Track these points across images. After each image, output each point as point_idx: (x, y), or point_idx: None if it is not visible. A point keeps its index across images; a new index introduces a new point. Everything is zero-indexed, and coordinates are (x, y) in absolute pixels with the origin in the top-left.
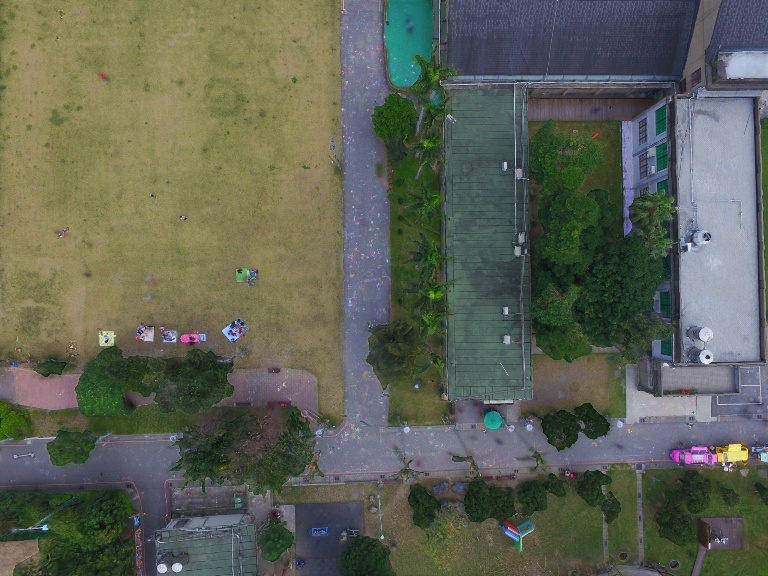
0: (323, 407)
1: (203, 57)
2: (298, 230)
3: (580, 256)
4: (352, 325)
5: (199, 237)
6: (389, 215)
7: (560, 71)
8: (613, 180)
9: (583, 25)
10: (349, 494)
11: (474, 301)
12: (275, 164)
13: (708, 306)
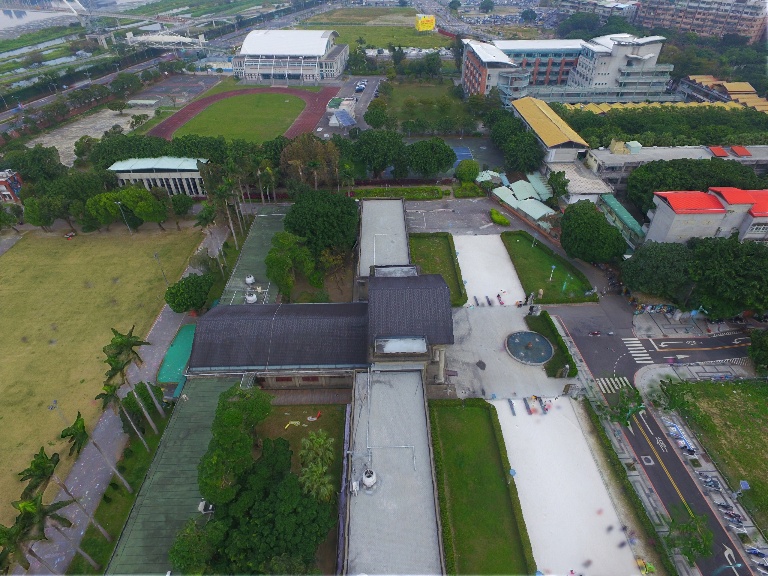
0: None
1: (21, 368)
2: (7, 500)
3: (233, 492)
4: None
5: None
6: (107, 485)
7: (278, 363)
8: (334, 451)
9: (293, 333)
10: None
11: (139, 567)
12: (25, 441)
13: (382, 555)
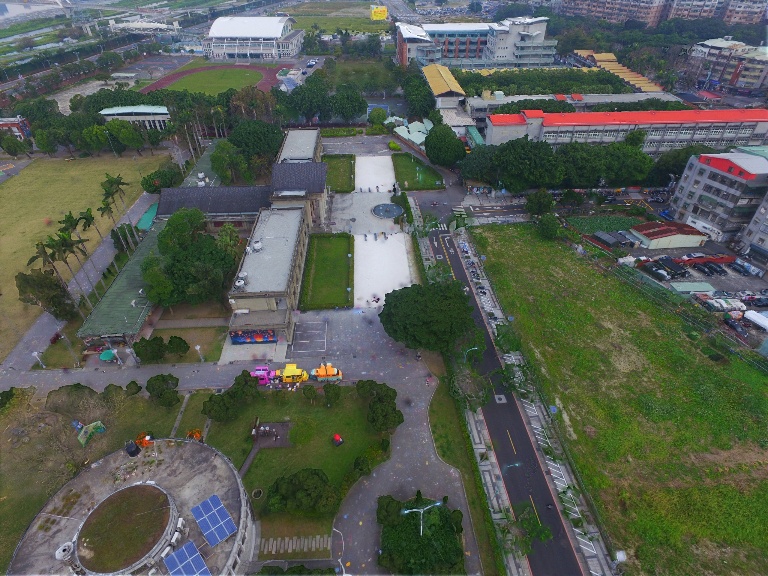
0: None
1: (43, 225)
2: None
3: (178, 248)
4: (45, 318)
5: None
6: (105, 273)
7: (215, 212)
8: None
9: (225, 196)
10: None
11: (124, 290)
12: None
13: (258, 273)
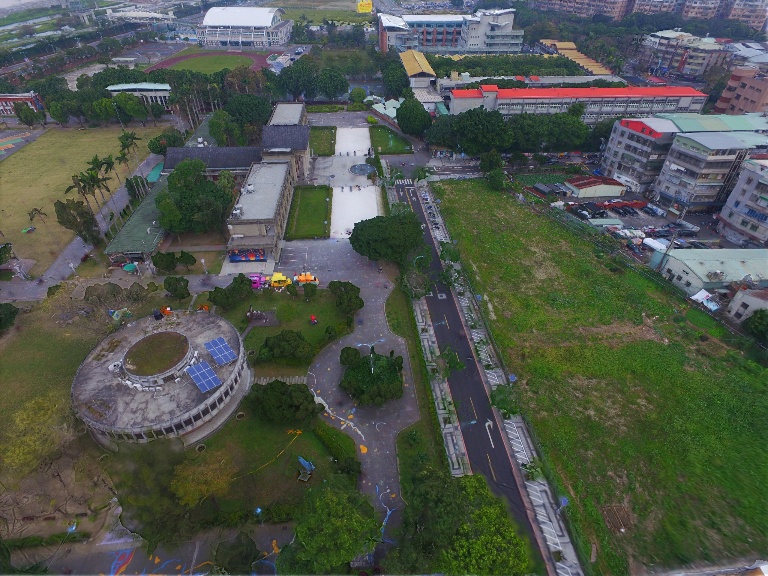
0: (31, 272)
1: (64, 179)
2: None
3: None
4: (74, 245)
5: (14, 220)
6: None
7: (213, 167)
8: None
9: (222, 154)
10: (16, 306)
11: None
12: None
13: (251, 207)
